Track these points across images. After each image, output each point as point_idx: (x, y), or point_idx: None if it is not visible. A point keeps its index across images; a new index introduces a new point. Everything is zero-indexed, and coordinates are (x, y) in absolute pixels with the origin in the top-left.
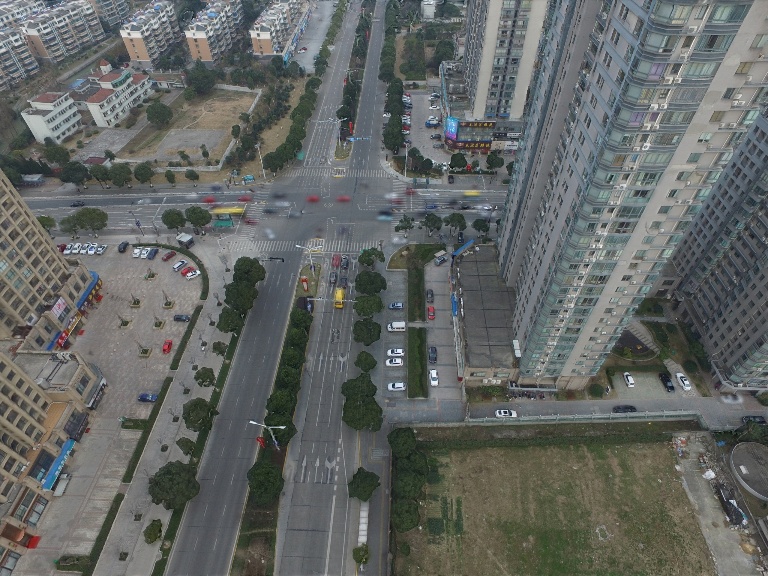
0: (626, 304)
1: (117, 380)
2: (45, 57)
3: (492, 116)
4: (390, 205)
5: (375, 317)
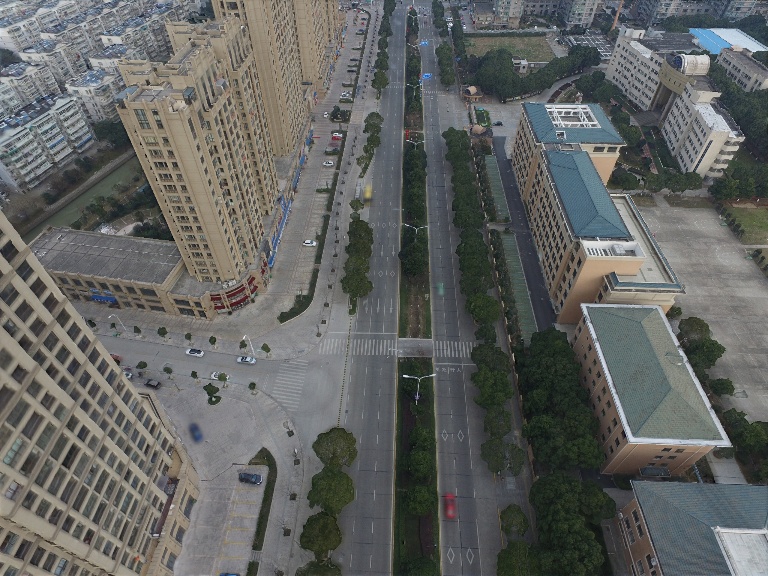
0: None
1: None
2: None
3: None
4: None
5: None
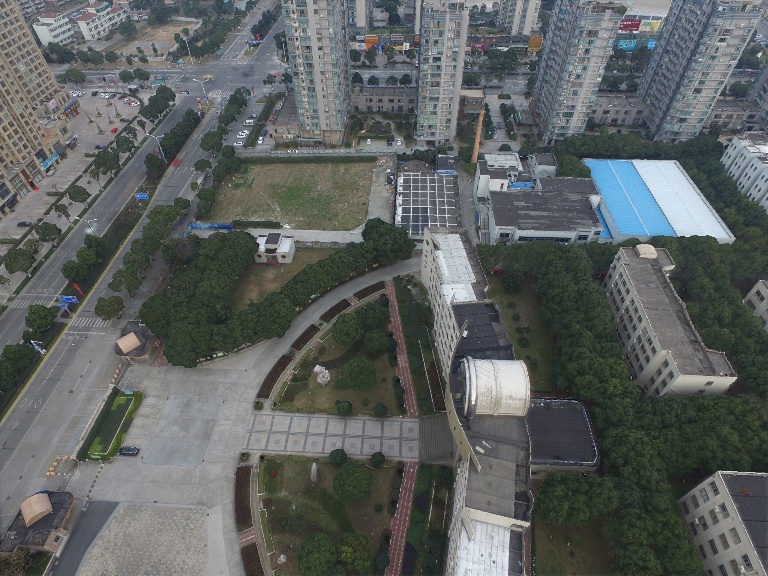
0: (330, 69)
1: (84, 142)
2: (51, 0)
3: None
4: None
5: (239, 121)
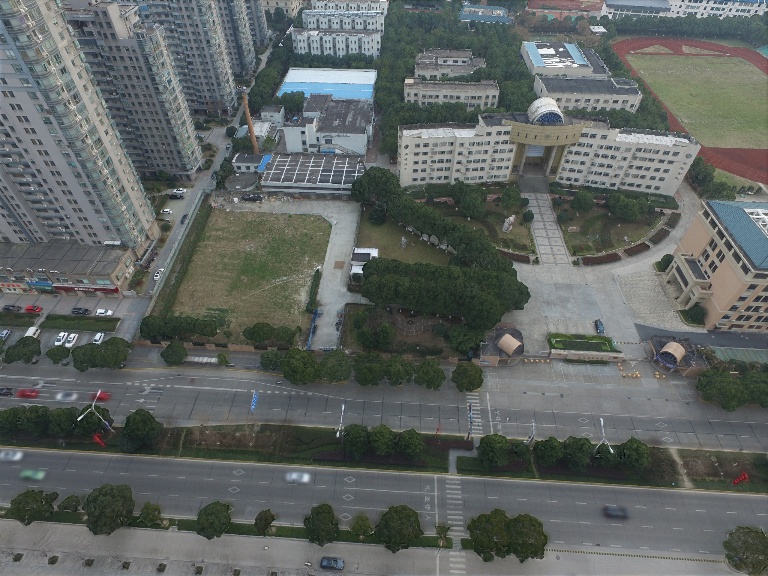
0: (121, 152)
1: None
2: None
3: None
4: None
5: None
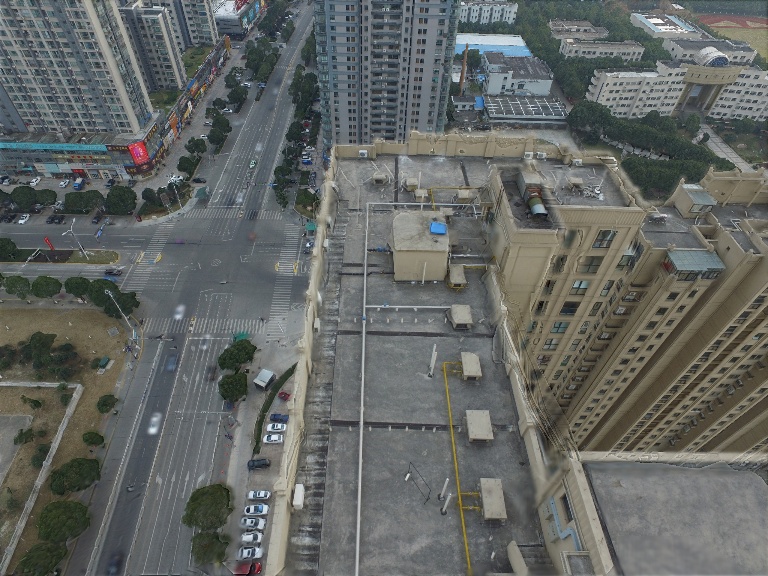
0: None
1: None
2: None
3: (144, 122)
4: (230, 219)
5: None
